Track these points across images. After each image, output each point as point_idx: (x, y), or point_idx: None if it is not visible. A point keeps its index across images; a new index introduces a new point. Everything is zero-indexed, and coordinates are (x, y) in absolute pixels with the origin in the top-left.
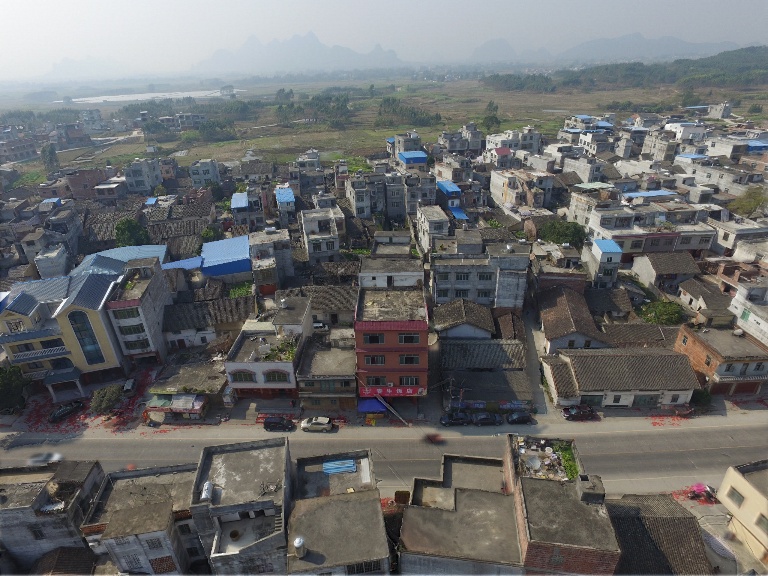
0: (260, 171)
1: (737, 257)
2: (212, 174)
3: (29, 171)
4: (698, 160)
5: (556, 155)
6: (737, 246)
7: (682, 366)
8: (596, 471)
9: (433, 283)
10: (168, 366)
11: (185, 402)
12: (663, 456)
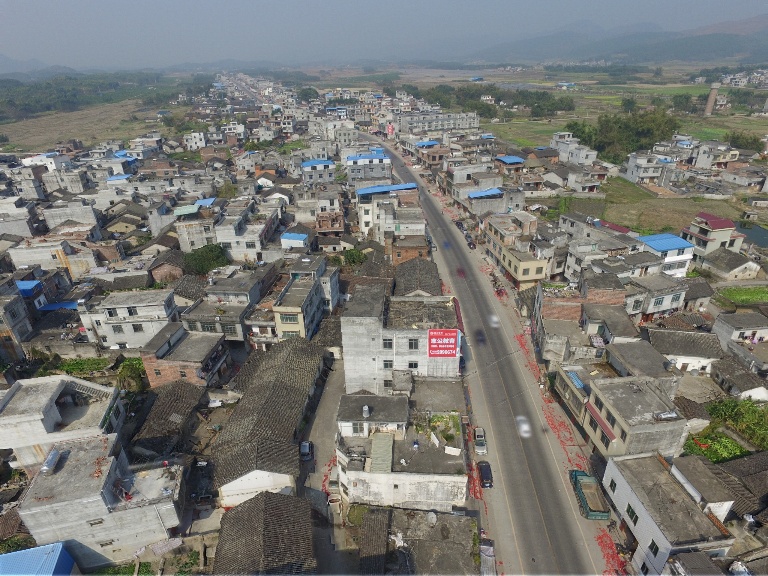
0: None
1: (299, 219)
2: None
3: None
4: (132, 179)
5: (17, 212)
6: (295, 212)
7: (425, 261)
8: (492, 316)
9: (304, 324)
10: None
11: (487, 568)
12: (475, 296)
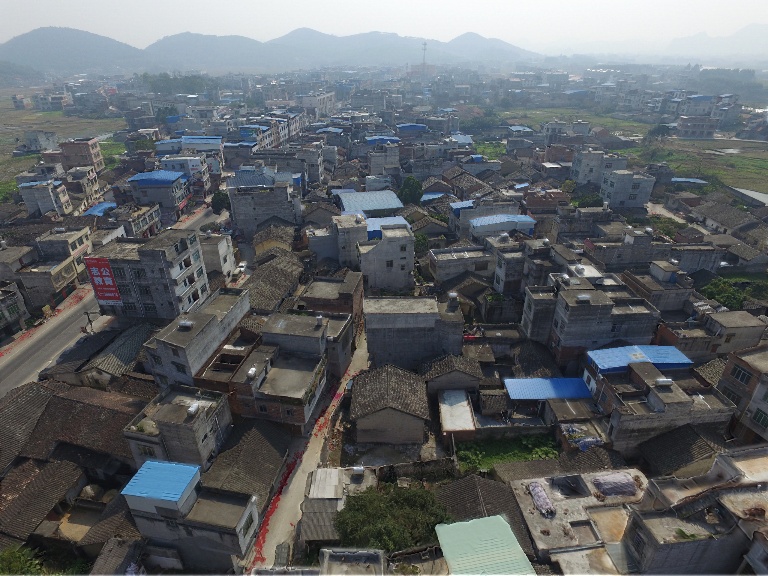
0: (722, 219)
1: None
2: (615, 189)
3: (651, 146)
4: None
5: None
6: None
7: None
8: None
9: None
10: (247, 243)
11: None
12: None
